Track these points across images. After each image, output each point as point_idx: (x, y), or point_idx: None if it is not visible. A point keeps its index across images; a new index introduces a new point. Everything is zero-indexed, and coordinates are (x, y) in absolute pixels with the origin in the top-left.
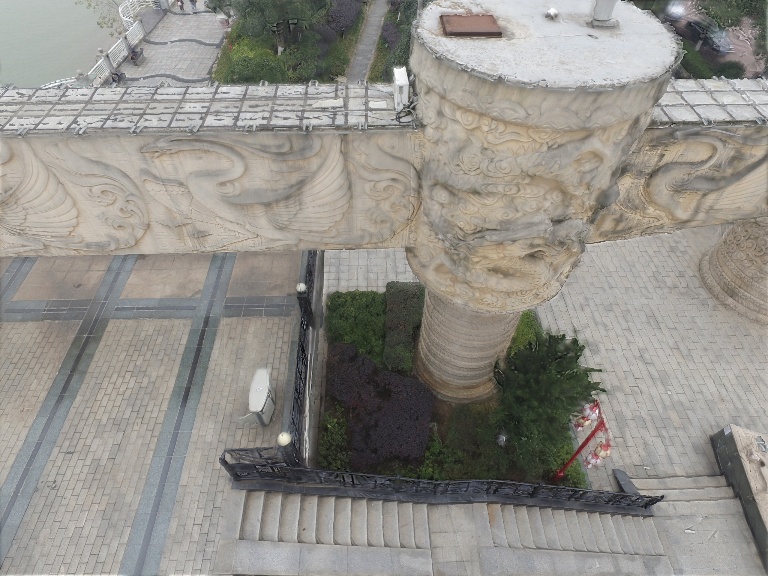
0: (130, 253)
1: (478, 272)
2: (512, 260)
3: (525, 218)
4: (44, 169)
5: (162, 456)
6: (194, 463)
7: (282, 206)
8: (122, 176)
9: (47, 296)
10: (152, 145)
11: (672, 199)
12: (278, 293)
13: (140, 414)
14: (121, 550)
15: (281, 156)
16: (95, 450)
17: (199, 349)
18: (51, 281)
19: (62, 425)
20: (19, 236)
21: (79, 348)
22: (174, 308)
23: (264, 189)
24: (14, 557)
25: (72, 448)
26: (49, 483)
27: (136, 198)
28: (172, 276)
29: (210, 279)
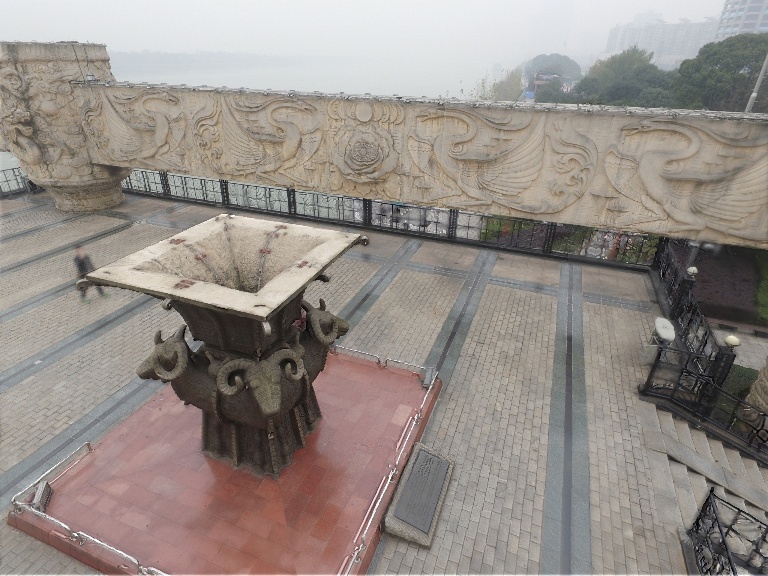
0: (548, 220)
1: None
2: None
3: None
4: (542, 137)
5: (562, 364)
6: (595, 375)
7: (709, 190)
8: (594, 148)
9: (434, 264)
10: (636, 124)
11: None
12: (631, 298)
13: (533, 336)
14: (547, 408)
15: (735, 142)
16: (501, 346)
17: (570, 313)
18: (435, 257)
19: (469, 327)
20: (481, 191)
21: (468, 293)
22: (538, 288)
23: (701, 172)
24: (455, 386)
25: (482, 341)
26: (469, 355)
27: (592, 167)
28: (530, 272)
29: (564, 279)
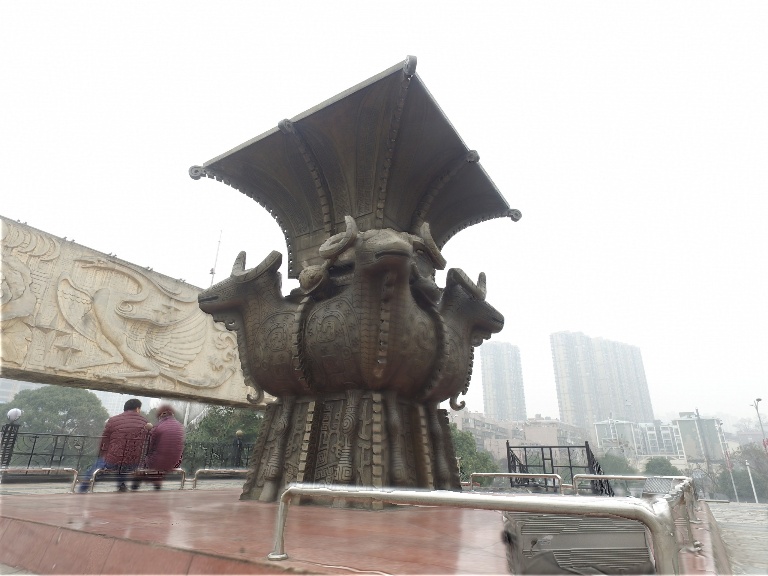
0: (209, 396)
1: None
2: None
3: None
4: (205, 314)
5: None
6: None
7: None
8: None
9: None
10: None
11: None
12: None
13: None
14: None
15: None
16: None
17: None
18: None
19: None
20: (148, 359)
21: None
22: None
23: None
24: None
25: None
26: None
27: None
28: None
29: None
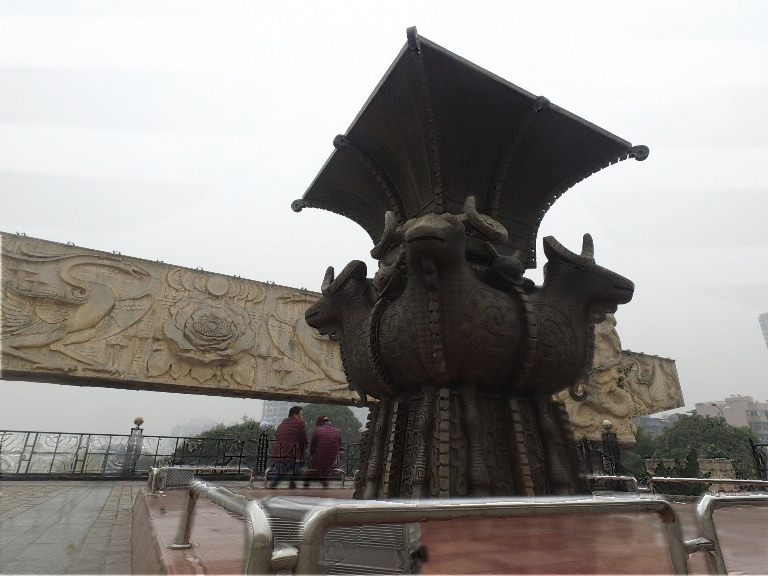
0: None
1: (604, 396)
2: (615, 382)
3: (607, 360)
4: None
5: None
6: None
7: None
8: None
9: None
10: None
11: (640, 389)
12: None
13: None
14: None
15: None
16: None
17: None
18: None
19: None
20: None
21: None
22: None
23: None
24: None
25: None
26: None
27: None
28: None
29: None
